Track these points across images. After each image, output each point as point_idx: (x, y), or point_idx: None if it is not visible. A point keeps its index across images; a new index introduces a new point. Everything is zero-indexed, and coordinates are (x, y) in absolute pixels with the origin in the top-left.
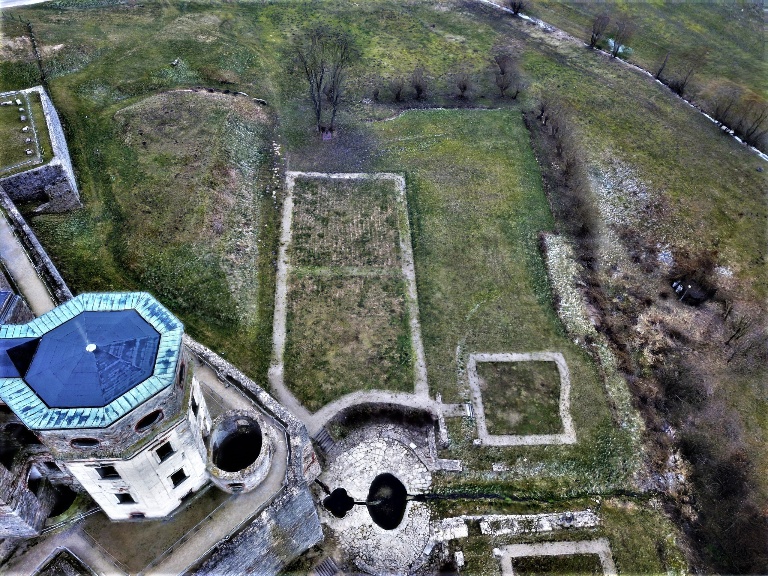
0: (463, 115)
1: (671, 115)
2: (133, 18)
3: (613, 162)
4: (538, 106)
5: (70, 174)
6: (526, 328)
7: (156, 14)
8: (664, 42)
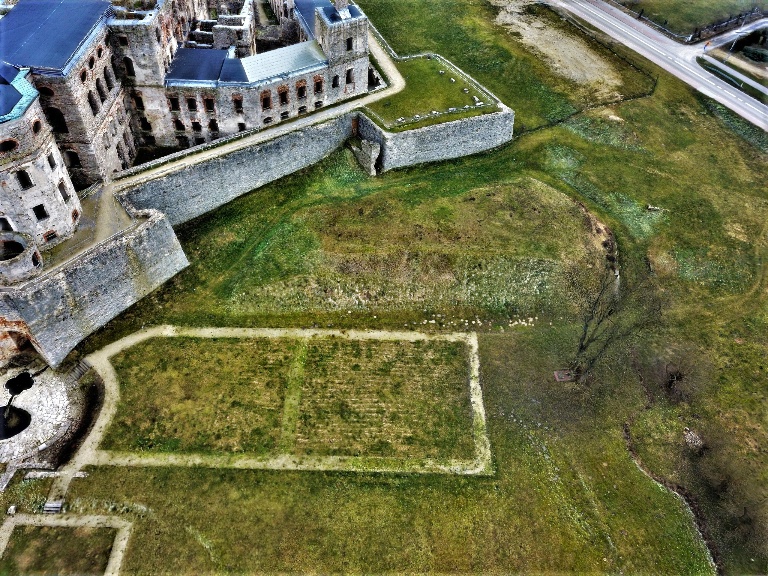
0: None
1: None
2: (739, 165)
3: None
4: None
5: (401, 156)
6: None
7: (765, 182)
8: None
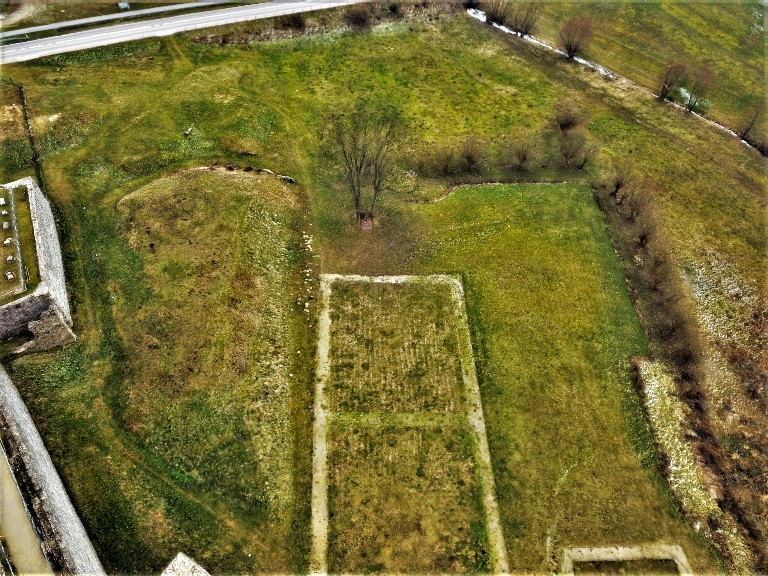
0: (524, 192)
1: (767, 188)
2: (141, 74)
3: (706, 253)
4: (612, 182)
5: (61, 297)
6: (631, 506)
7: (167, 68)
8: (745, 92)
